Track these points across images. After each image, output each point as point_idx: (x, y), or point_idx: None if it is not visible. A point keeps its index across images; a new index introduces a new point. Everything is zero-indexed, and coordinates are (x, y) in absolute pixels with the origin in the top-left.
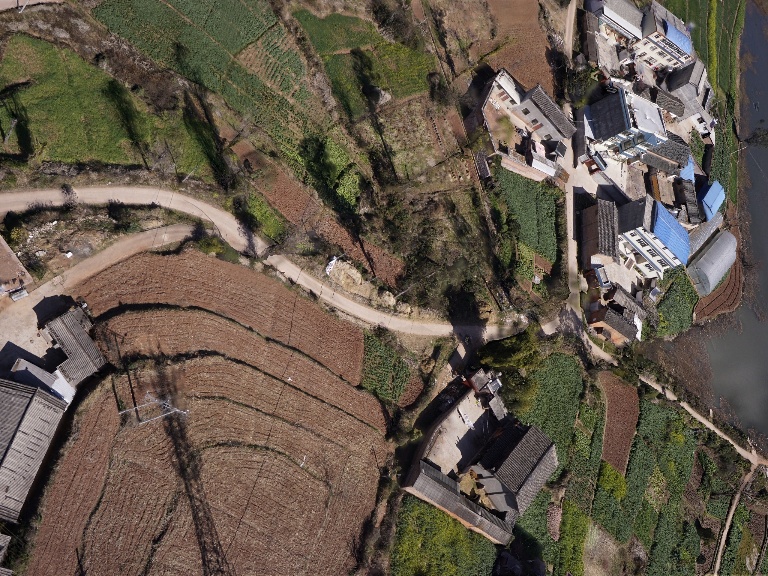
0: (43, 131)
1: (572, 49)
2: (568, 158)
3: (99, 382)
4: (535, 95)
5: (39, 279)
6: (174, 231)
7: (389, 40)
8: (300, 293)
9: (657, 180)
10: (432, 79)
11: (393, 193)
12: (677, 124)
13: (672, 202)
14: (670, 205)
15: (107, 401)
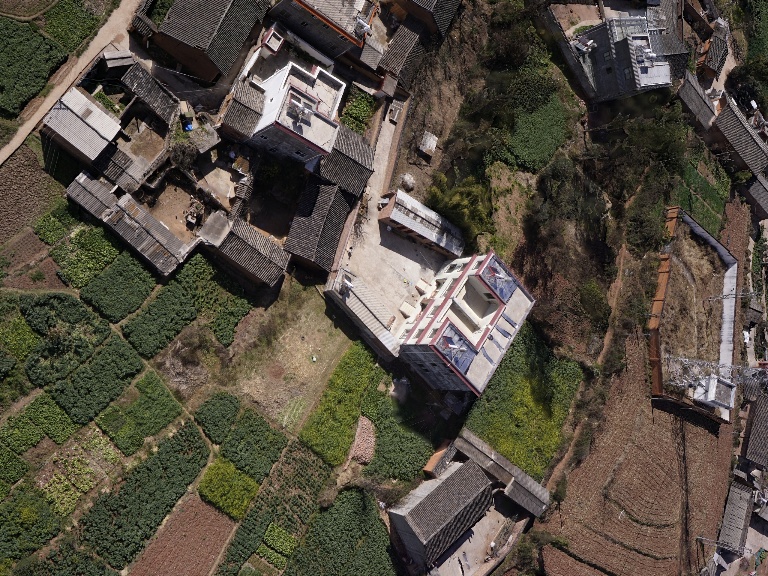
0: None
1: None
2: None
3: None
4: None
5: None
6: None
7: None
8: None
9: None
10: None
11: None
12: None
13: None
14: None
15: None
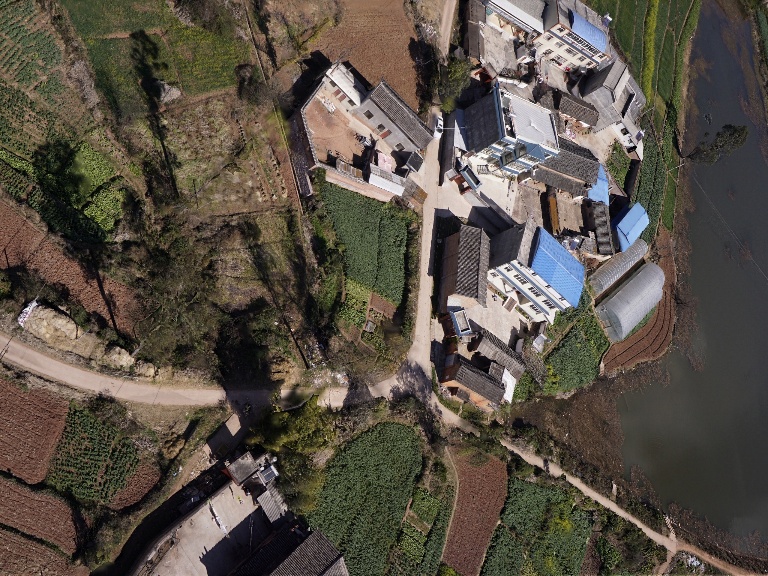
0: None
1: (450, 42)
2: (431, 173)
3: None
4: (375, 94)
5: None
6: None
7: (186, 23)
8: None
9: (556, 201)
10: (241, 72)
11: (172, 215)
12: (593, 135)
13: (579, 228)
14: (575, 232)
15: None
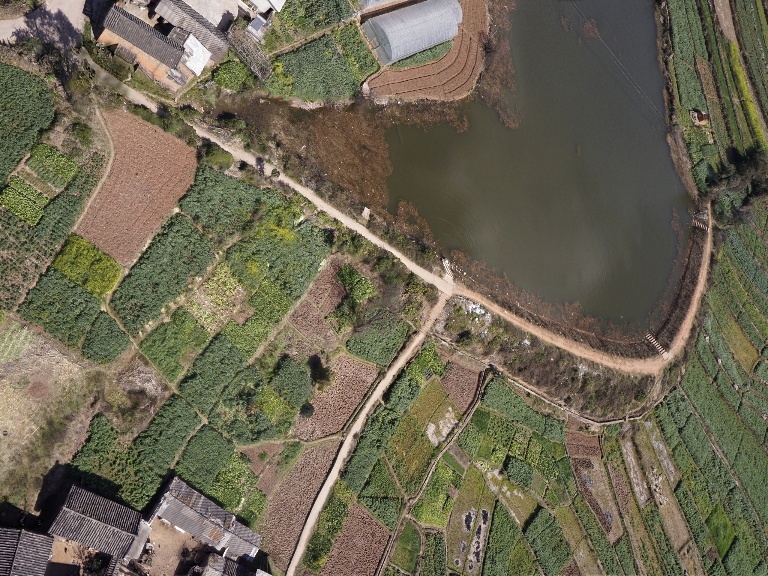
0: None
1: None
2: None
3: None
4: None
5: None
6: None
7: None
8: None
9: None
10: None
11: None
12: None
13: None
14: None
15: None
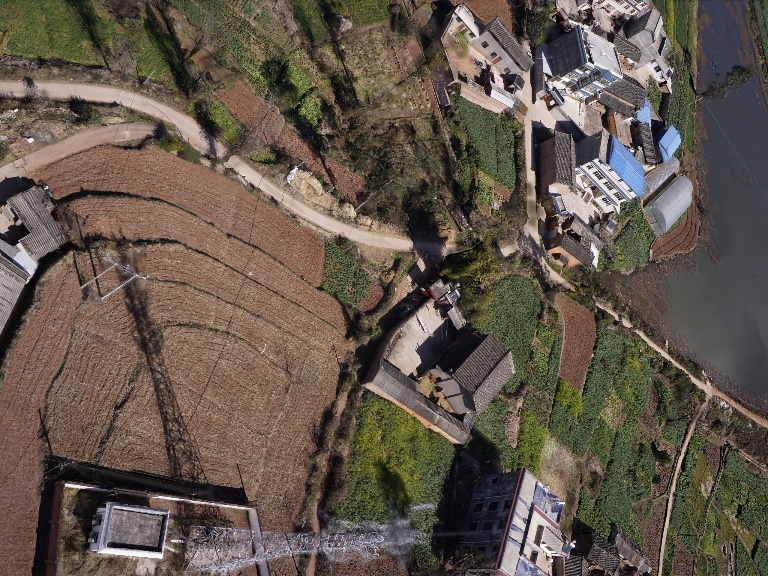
0: (4, 26)
1: None
2: (527, 93)
3: (61, 257)
4: (493, 27)
5: (1, 160)
6: (136, 129)
7: None
8: (261, 197)
9: (614, 121)
10: (393, 9)
11: (354, 117)
12: (634, 71)
13: (629, 144)
14: (627, 146)
15: (69, 275)
